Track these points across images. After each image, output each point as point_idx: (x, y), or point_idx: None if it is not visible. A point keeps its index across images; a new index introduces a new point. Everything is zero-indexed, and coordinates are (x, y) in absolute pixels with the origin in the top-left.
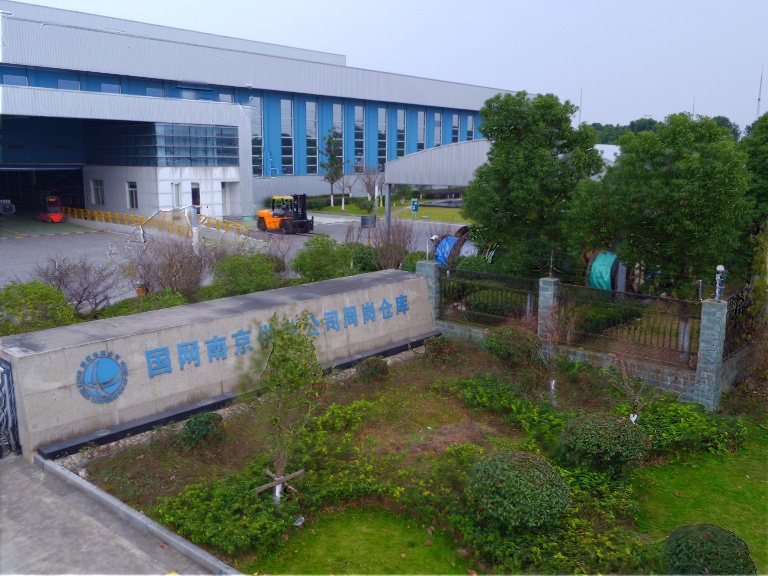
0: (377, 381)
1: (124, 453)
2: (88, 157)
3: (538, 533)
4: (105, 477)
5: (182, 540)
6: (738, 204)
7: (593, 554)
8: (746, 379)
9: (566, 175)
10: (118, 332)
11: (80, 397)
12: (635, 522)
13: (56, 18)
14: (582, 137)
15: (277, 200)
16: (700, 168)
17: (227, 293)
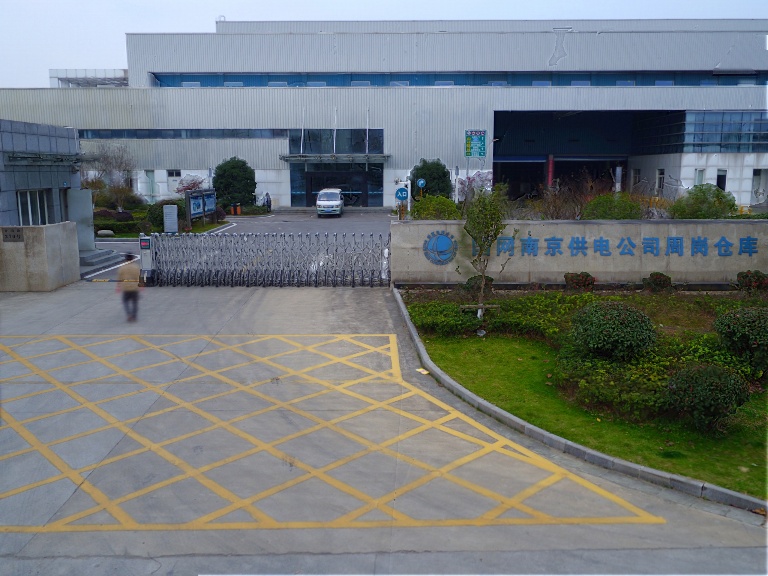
0: (653, 292)
1: None
2: (633, 149)
3: (608, 361)
4: None
5: (411, 323)
6: None
7: (629, 377)
8: None
9: None
10: None
11: (424, 257)
12: None
13: (610, 25)
14: None
15: None
16: None
17: None
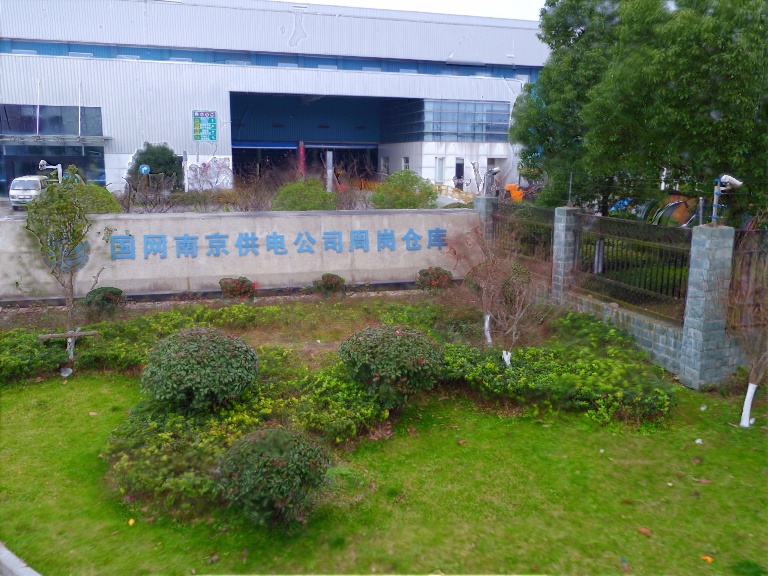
0: (324, 297)
1: None
2: (382, 137)
3: (188, 416)
4: None
5: None
6: None
7: (198, 443)
8: None
9: None
10: None
11: (43, 264)
12: (357, 450)
13: (348, 8)
14: None
15: None
16: (684, 28)
17: None
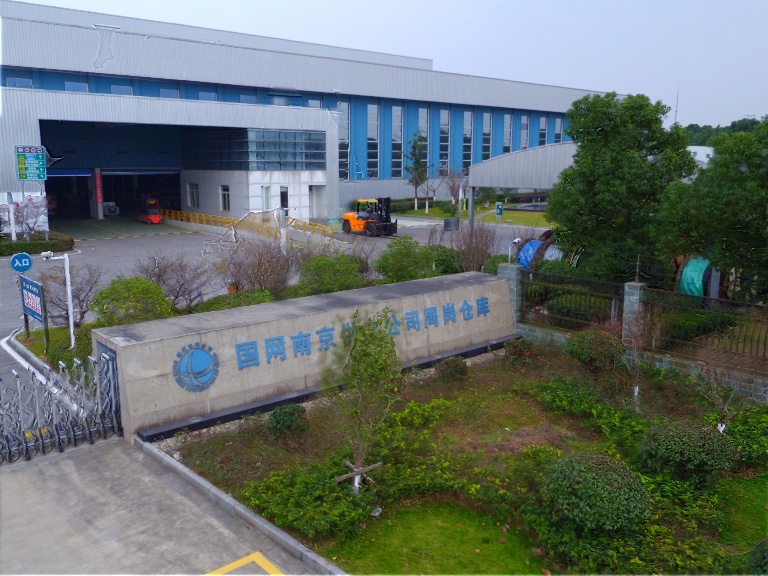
0: (456, 381)
1: (214, 439)
2: (185, 162)
3: (615, 537)
4: (197, 460)
5: (266, 522)
6: None
7: (672, 561)
8: None
9: (655, 177)
10: (211, 326)
11: (176, 385)
12: (719, 533)
13: (159, 31)
14: (673, 138)
15: (362, 203)
16: None
17: (312, 292)
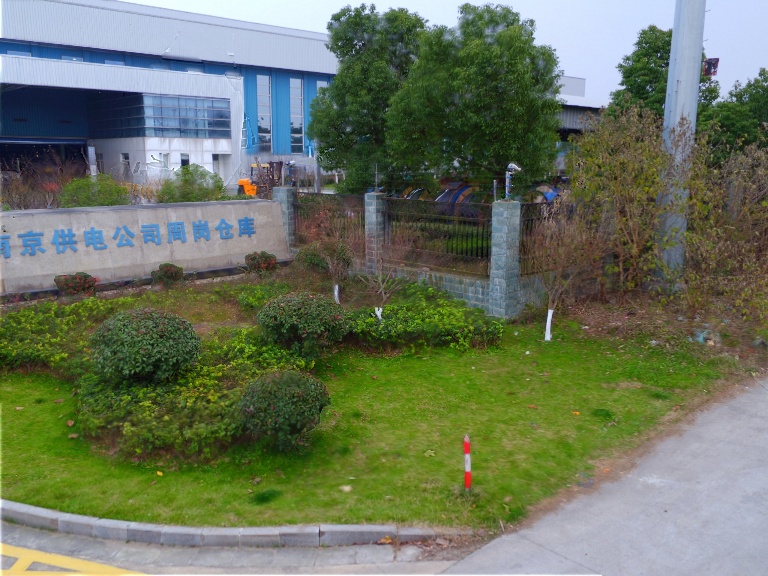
0: (166, 286)
1: None
2: (91, 132)
3: (150, 387)
4: None
5: None
6: (545, 101)
7: (184, 404)
8: (562, 294)
9: None
10: None
11: None
12: None
13: None
14: None
15: (255, 168)
16: (479, 54)
17: None
